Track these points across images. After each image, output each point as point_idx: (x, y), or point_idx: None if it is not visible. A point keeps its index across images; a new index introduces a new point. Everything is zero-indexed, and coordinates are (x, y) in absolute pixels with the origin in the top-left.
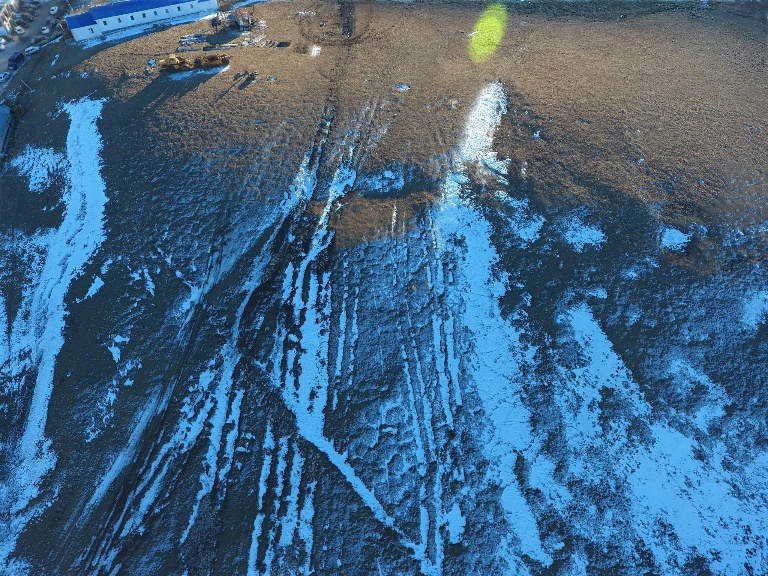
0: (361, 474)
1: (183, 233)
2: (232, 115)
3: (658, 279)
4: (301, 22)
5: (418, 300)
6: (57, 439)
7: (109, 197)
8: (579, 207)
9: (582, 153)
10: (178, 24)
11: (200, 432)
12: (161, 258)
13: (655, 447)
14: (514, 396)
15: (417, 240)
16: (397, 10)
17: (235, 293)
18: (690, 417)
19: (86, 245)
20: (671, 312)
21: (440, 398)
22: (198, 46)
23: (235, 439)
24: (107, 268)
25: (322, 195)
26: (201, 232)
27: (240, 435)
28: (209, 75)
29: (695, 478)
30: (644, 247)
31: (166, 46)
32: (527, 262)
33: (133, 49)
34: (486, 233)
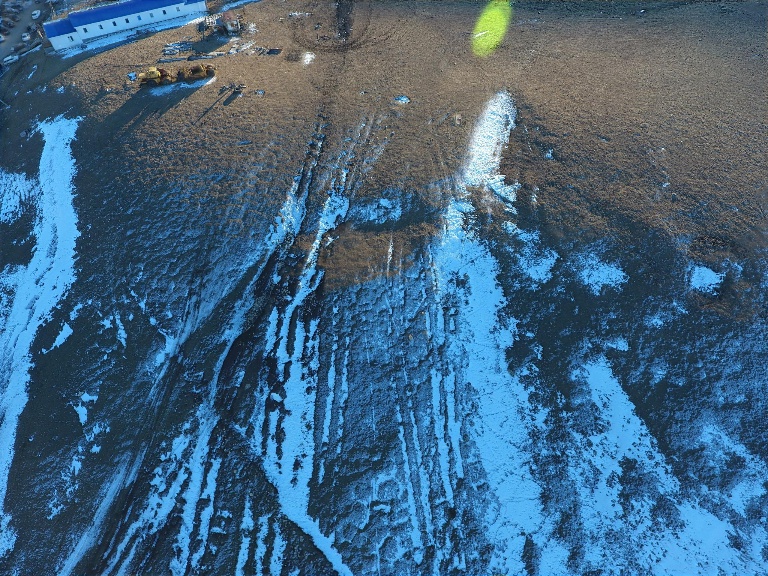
0: (349, 561)
1: (159, 273)
2: (215, 135)
3: (686, 328)
4: (294, 25)
5: (415, 352)
6: (16, 515)
7: (81, 231)
8: (596, 241)
9: (600, 176)
10: (163, 30)
11: (171, 509)
12: (134, 303)
13: (684, 531)
14: (522, 467)
15: (415, 280)
16: (398, 8)
17: (214, 344)
18: (724, 496)
19: (55, 286)
20: (702, 368)
21: (439, 469)
22: (182, 55)
23: (210, 518)
24: (76, 314)
25: (311, 228)
26: (178, 272)
27: (215, 513)
28: (192, 89)
29: (730, 570)
30: (670, 289)
31: (148, 56)
32: (538, 307)
33: (113, 59)
34: (492, 272)
